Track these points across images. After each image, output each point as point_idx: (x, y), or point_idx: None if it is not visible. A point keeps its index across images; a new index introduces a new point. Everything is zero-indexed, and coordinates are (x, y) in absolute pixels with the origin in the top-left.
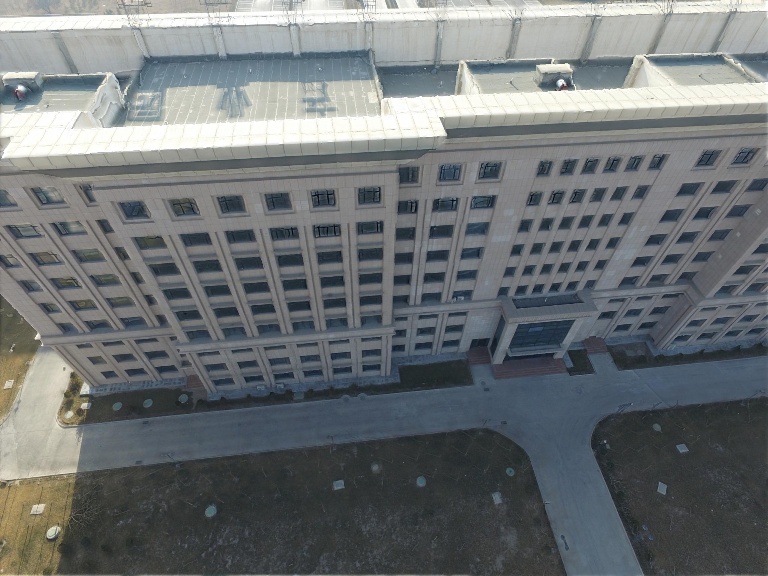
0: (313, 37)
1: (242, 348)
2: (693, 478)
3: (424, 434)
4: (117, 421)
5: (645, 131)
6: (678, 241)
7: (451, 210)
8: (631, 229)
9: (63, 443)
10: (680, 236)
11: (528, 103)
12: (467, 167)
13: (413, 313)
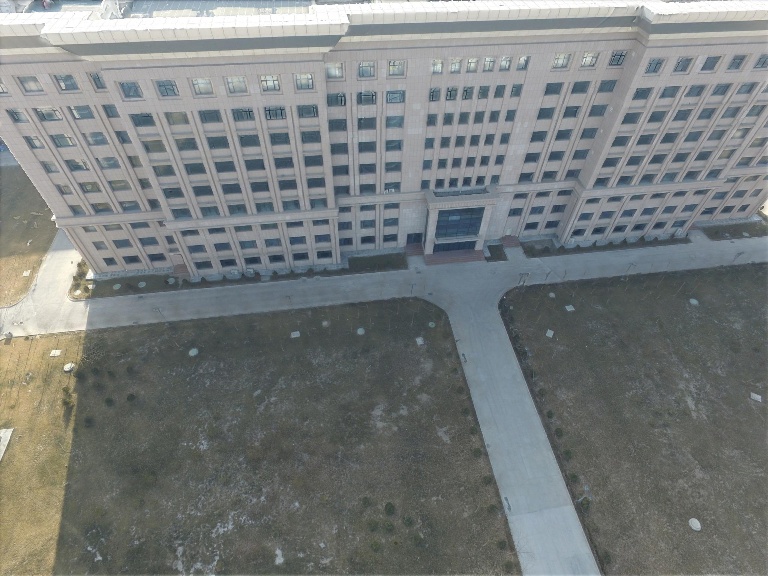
0: None
1: (217, 227)
2: (575, 327)
3: (365, 301)
4: (117, 296)
5: (505, 34)
6: (558, 139)
7: (372, 104)
8: (516, 125)
9: (73, 311)
10: (558, 134)
11: (412, 7)
12: (378, 64)
13: (354, 203)
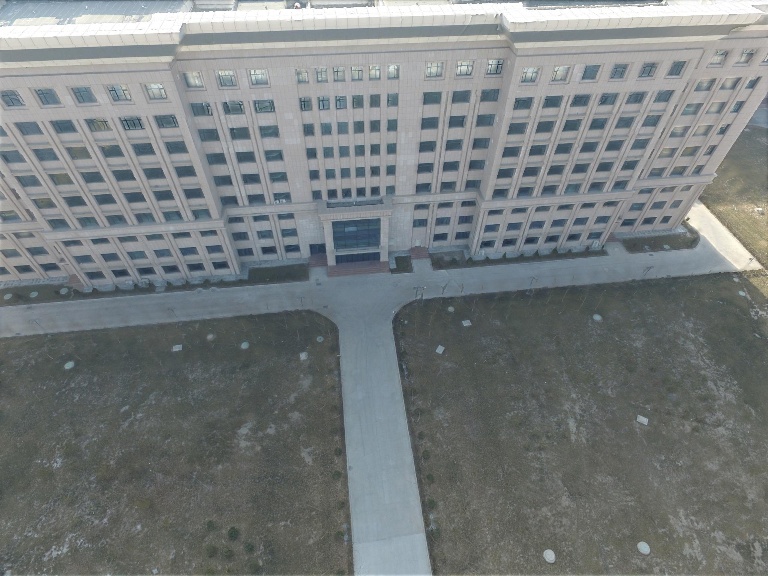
0: None
1: (98, 238)
2: (468, 343)
3: (257, 314)
4: (6, 306)
5: (365, 42)
6: (449, 149)
7: (241, 113)
8: (400, 135)
9: None
10: (448, 144)
11: (257, 15)
12: (237, 73)
13: (245, 214)
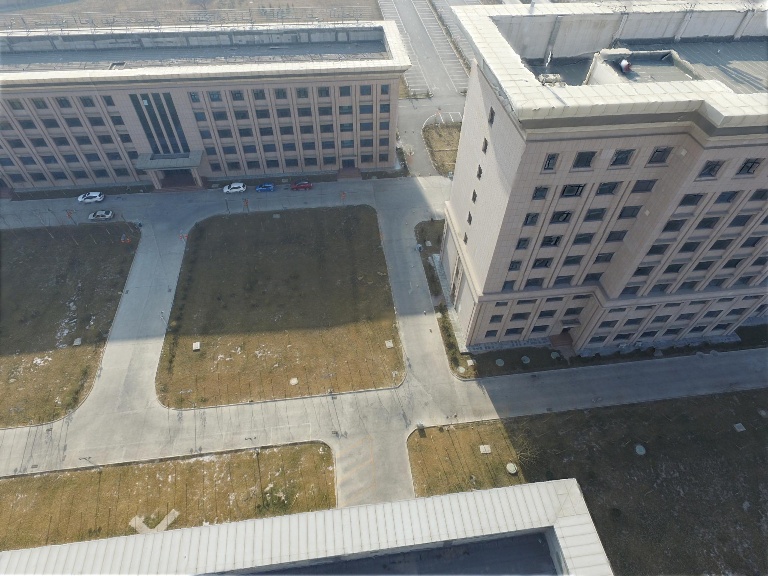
0: (757, 22)
1: (654, 304)
2: None
3: None
4: (508, 375)
5: None
6: None
7: None
8: None
9: (471, 394)
10: None
11: None
12: None
13: None
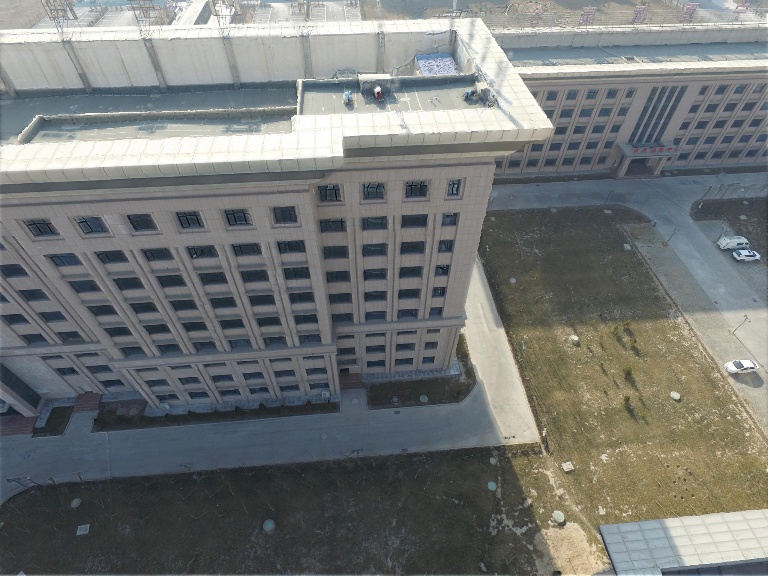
0: None
1: None
2: (65, 568)
3: None
4: None
5: None
6: (34, 298)
7: None
8: None
9: None
10: (27, 293)
11: None
12: None
13: None
